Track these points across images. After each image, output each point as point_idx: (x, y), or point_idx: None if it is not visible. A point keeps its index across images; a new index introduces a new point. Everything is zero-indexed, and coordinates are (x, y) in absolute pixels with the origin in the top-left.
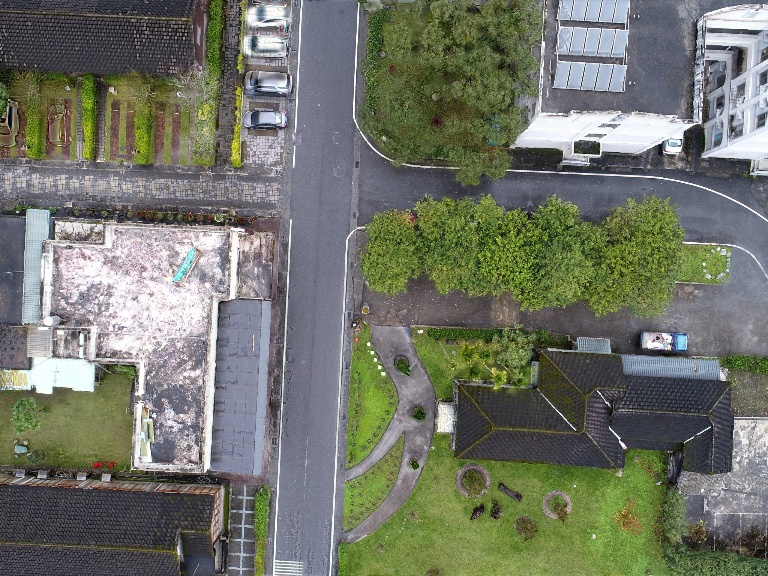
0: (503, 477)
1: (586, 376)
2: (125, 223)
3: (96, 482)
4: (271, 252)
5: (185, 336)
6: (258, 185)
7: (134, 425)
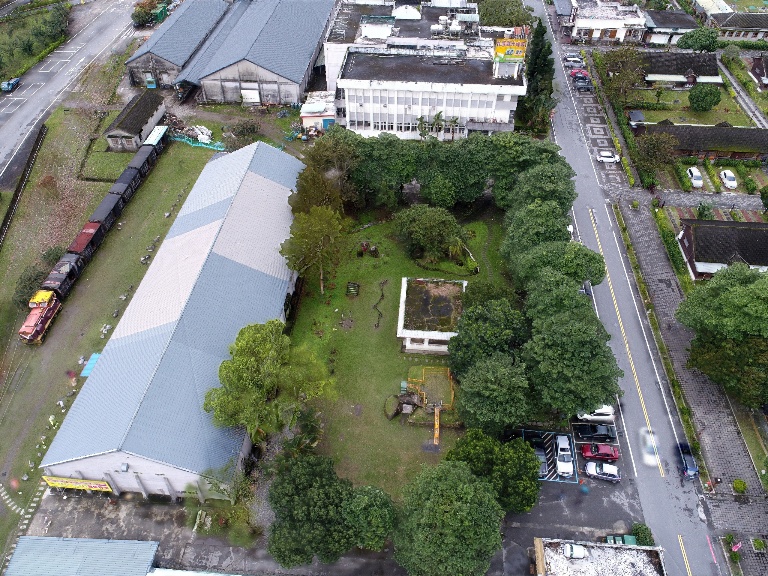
0: None
1: None
2: (617, 20)
3: (608, 1)
4: None
5: None
6: (571, 49)
7: None
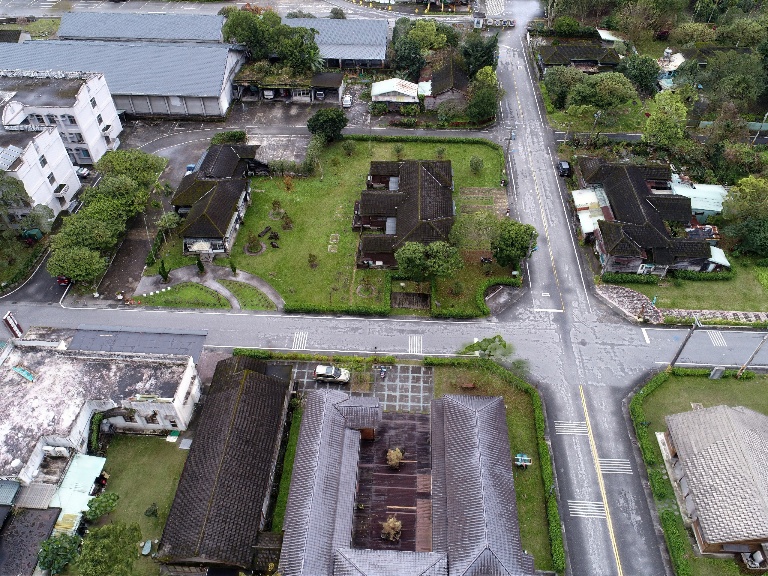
0: (255, 235)
1: (188, 184)
2: None
3: None
4: (44, 328)
5: (81, 375)
6: None
7: (137, 402)
